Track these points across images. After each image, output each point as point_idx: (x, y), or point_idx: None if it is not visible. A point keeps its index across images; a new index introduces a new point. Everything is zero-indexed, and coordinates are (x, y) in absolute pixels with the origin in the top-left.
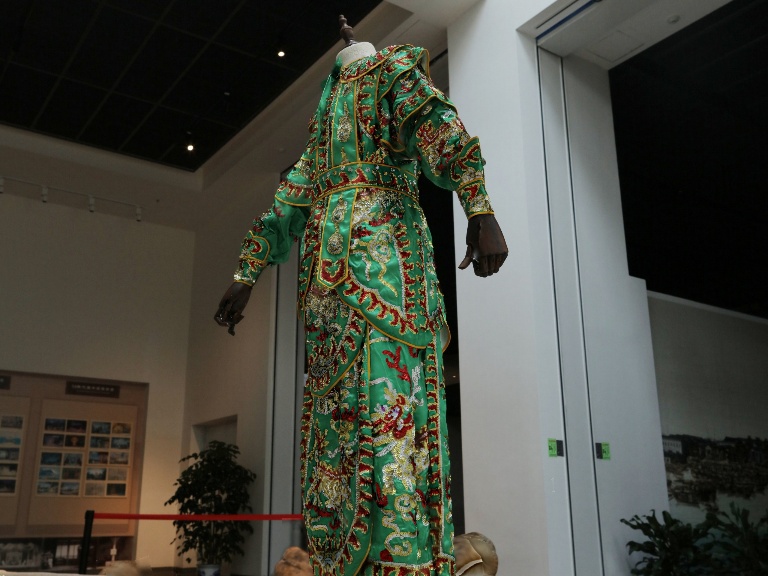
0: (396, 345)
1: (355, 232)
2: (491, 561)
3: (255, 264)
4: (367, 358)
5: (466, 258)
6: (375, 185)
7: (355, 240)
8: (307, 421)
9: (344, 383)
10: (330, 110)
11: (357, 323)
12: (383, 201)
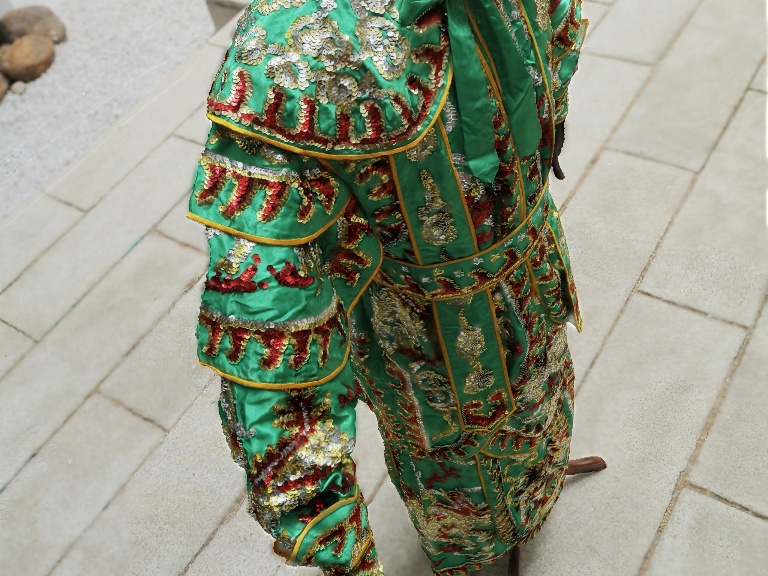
0: None
1: None
2: None
3: None
4: None
5: None
6: None
7: None
8: None
9: None
10: (531, 74)
11: None
12: None
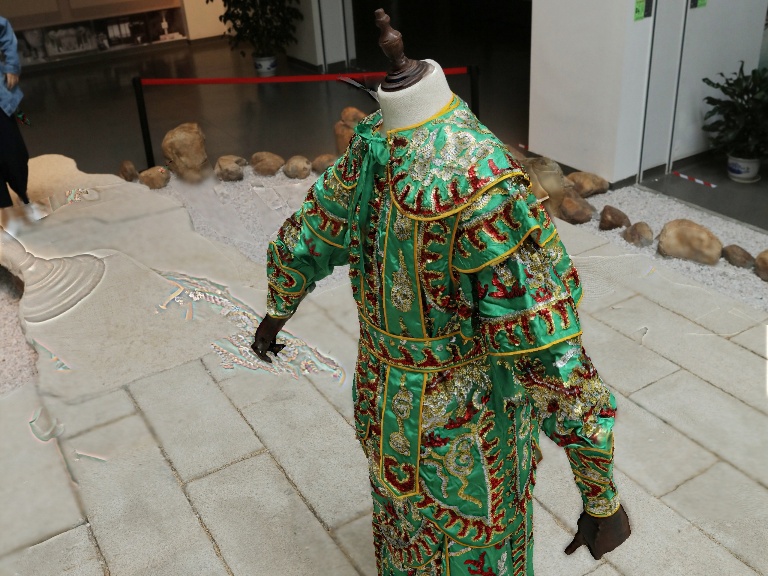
0: (480, 552)
1: (426, 439)
2: (558, 195)
3: (290, 298)
4: (446, 570)
5: (575, 544)
6: (451, 364)
7: (426, 450)
8: (379, 531)
9: (420, 574)
10: (376, 238)
11: (433, 531)
12: (462, 387)
